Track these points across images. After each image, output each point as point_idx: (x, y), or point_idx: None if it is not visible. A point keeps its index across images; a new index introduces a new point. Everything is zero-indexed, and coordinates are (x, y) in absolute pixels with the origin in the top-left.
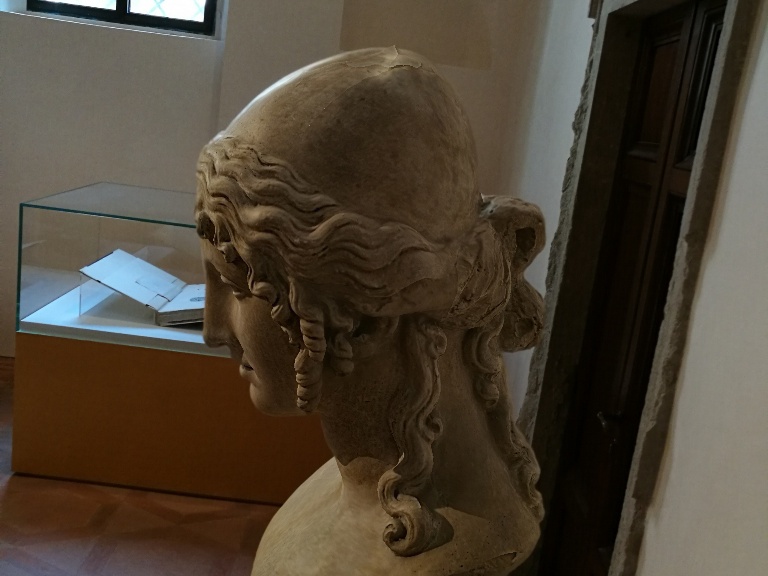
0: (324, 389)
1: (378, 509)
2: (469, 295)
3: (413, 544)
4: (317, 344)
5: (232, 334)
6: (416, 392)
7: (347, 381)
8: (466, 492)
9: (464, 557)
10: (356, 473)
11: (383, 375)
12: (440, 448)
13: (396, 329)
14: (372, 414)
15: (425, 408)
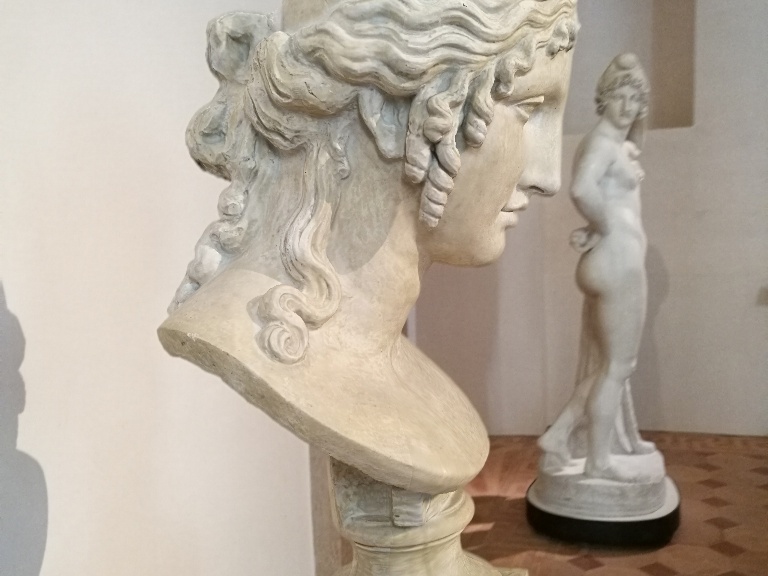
0: None
1: None
2: None
3: None
4: None
5: None
6: None
7: None
8: None
9: None
10: None
11: None
12: None
13: None
14: None
15: None
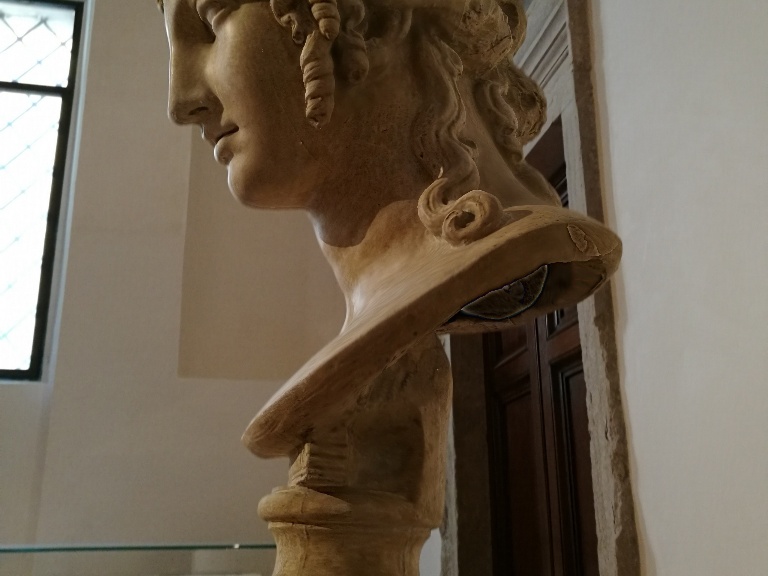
0: (331, 119)
1: (419, 255)
2: (478, 6)
3: (487, 219)
4: (331, 7)
5: (208, 90)
6: (441, 105)
7: (358, 108)
8: (526, 199)
9: (556, 216)
10: (379, 236)
11: (399, 98)
12: (479, 174)
13: (406, 47)
14: (392, 145)
15: (455, 122)
